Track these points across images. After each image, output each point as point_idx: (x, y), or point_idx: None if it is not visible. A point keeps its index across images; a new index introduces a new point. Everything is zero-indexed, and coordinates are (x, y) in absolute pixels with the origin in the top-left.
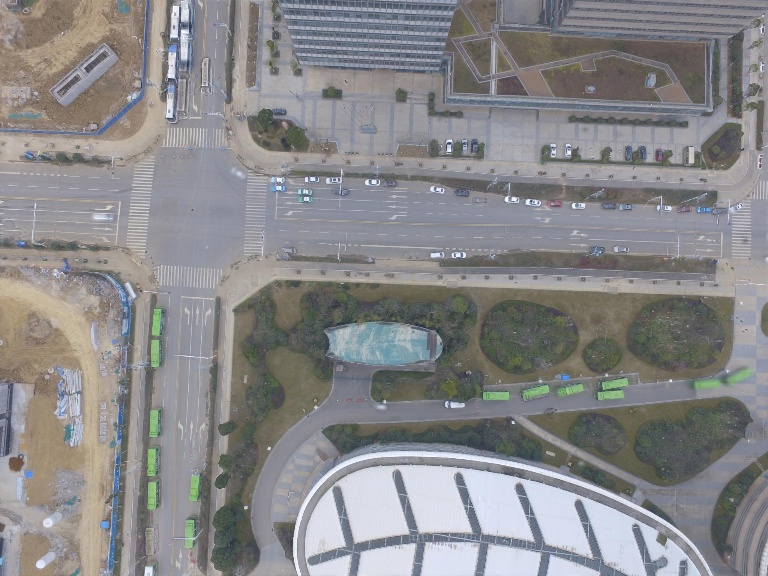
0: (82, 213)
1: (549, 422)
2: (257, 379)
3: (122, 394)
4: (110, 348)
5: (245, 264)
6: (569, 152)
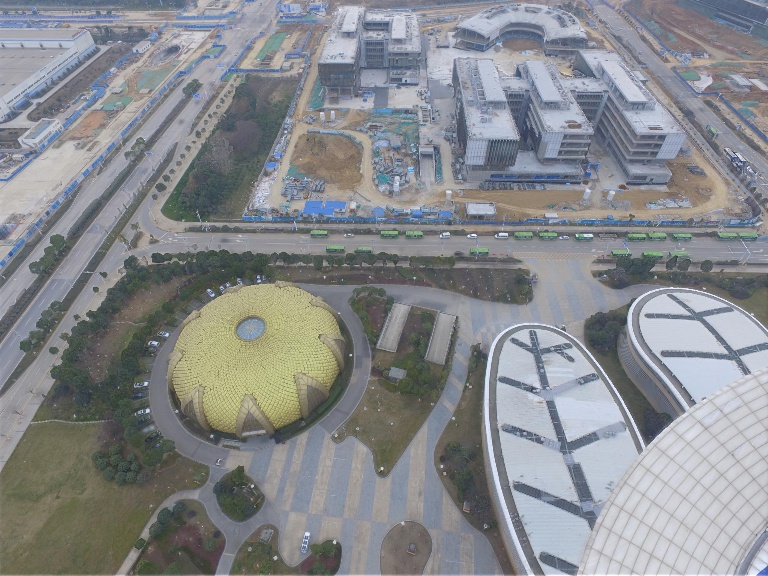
0: None
1: None
2: None
3: None
4: (714, 218)
5: None
6: None
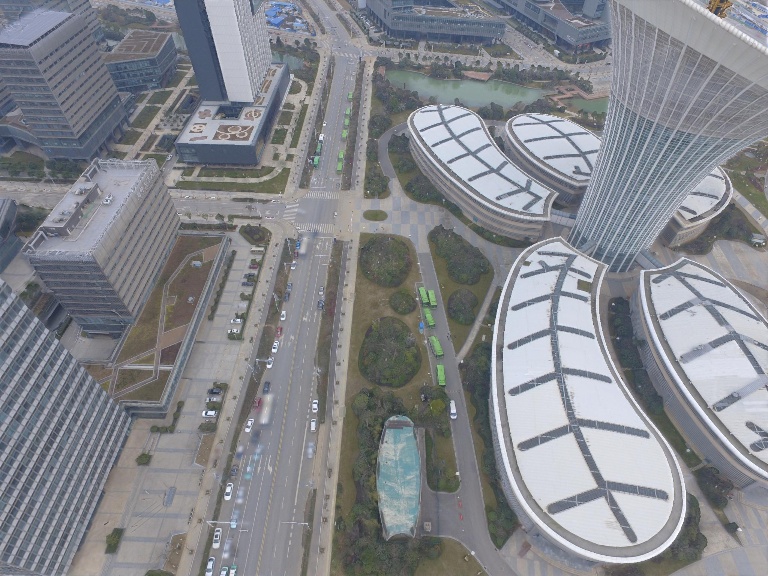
0: None
1: (459, 338)
2: None
3: None
4: None
5: None
6: (238, 320)
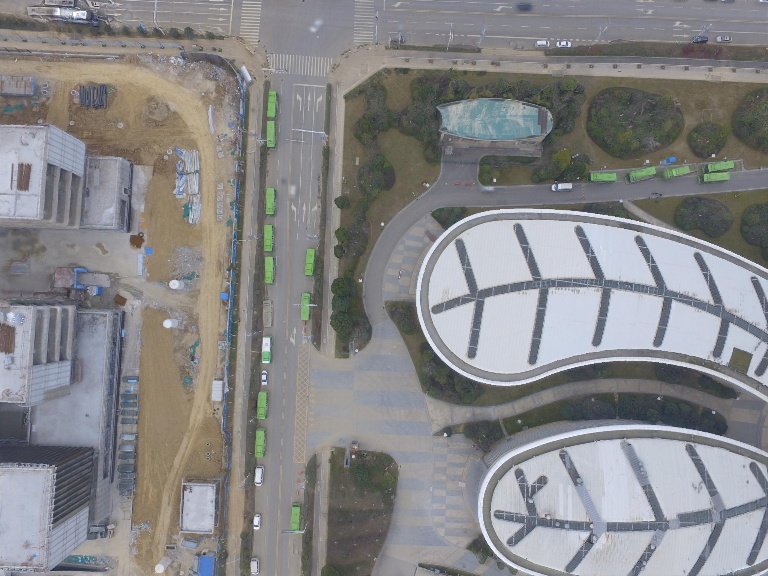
0: (197, 4)
1: (654, 206)
2: (369, 159)
3: (240, 171)
4: (226, 131)
5: (355, 53)
6: None
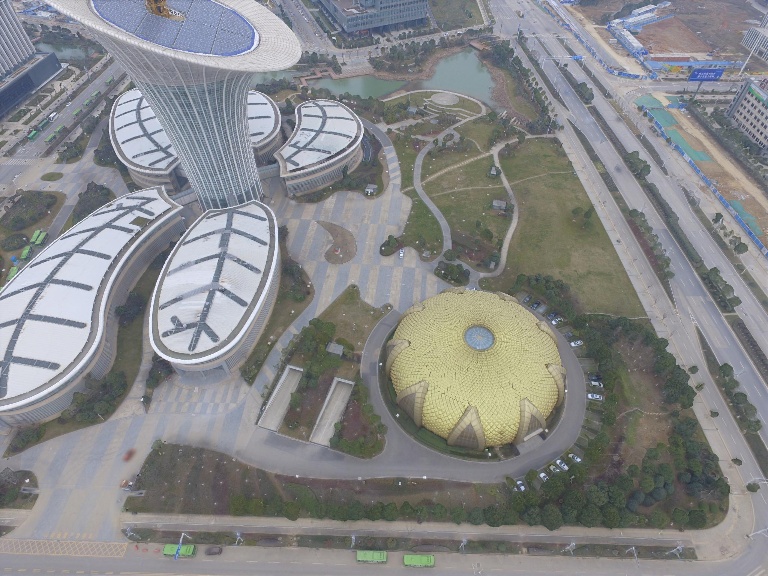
0: None
1: None
2: None
3: None
4: None
5: None
6: None
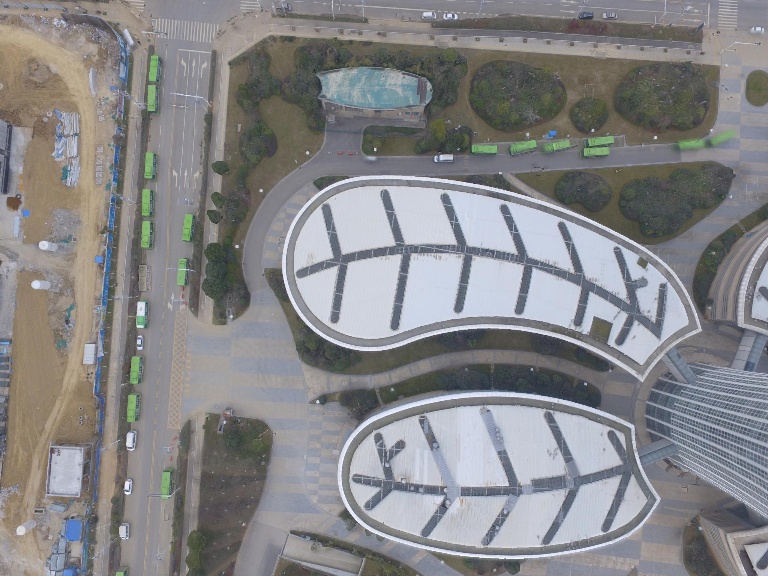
0: None
1: (536, 179)
2: (251, 126)
3: (118, 134)
4: (108, 94)
5: (241, 20)
6: None
